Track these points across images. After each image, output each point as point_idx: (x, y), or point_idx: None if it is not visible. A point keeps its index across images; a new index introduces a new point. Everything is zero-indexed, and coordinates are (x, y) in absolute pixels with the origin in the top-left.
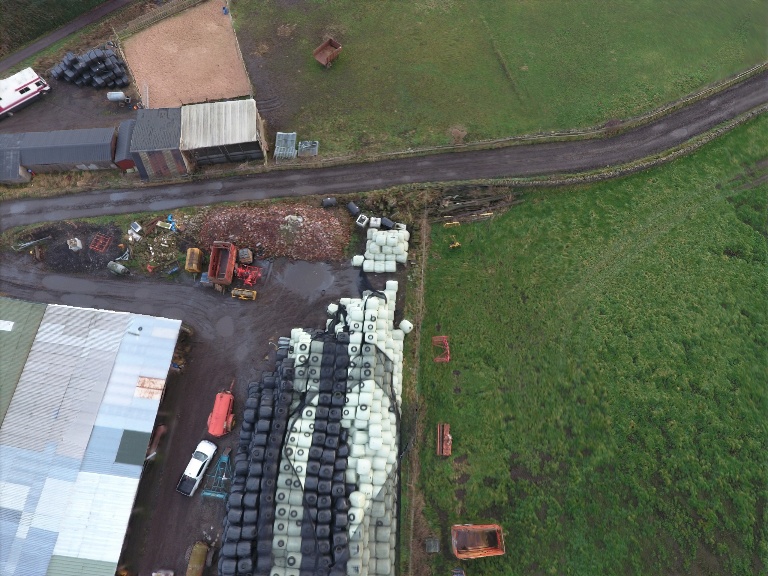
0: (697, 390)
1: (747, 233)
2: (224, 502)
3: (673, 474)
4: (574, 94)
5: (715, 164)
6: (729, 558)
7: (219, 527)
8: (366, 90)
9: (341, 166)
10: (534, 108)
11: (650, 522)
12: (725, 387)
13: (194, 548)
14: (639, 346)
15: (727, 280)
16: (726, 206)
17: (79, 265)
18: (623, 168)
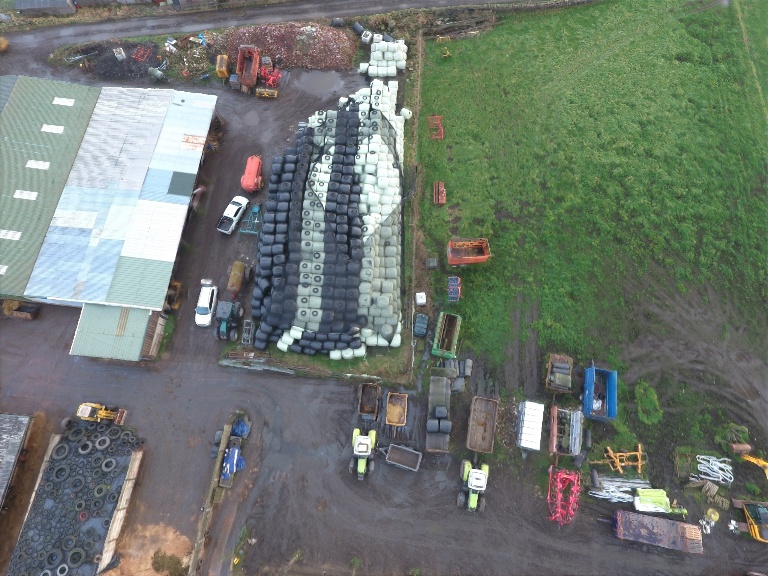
0: (650, 156)
1: (695, 44)
2: (257, 240)
3: (629, 213)
4: None
5: None
6: (674, 268)
7: (253, 257)
8: None
9: None
10: None
11: (610, 246)
12: (674, 153)
13: (235, 262)
14: (602, 125)
15: (677, 78)
16: (678, 25)
17: (123, 73)
18: None
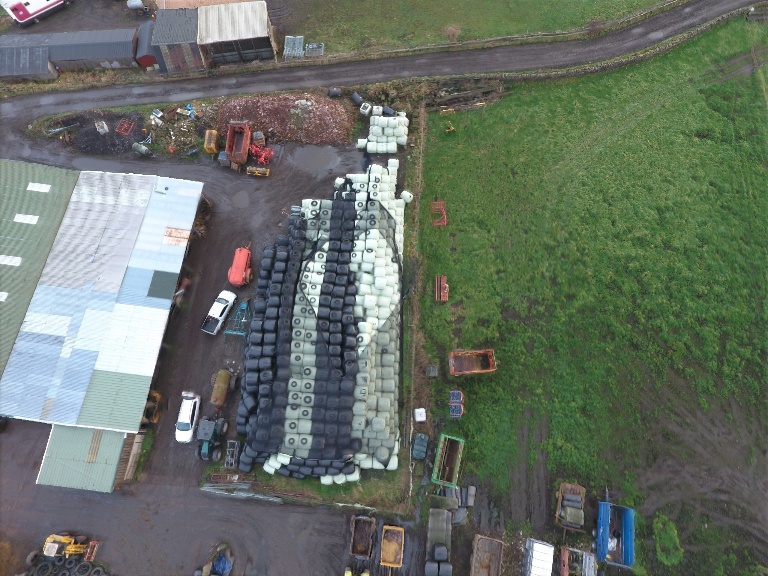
0: (669, 247)
1: (716, 119)
2: (244, 341)
3: (647, 314)
4: (559, 3)
5: (688, 62)
6: (695, 380)
7: (240, 361)
8: (367, 1)
9: (345, 63)
10: (523, 15)
11: (626, 353)
12: (694, 244)
13: (219, 371)
14: (617, 212)
15: (697, 158)
16: (697, 97)
17: (106, 148)
18: (604, 63)
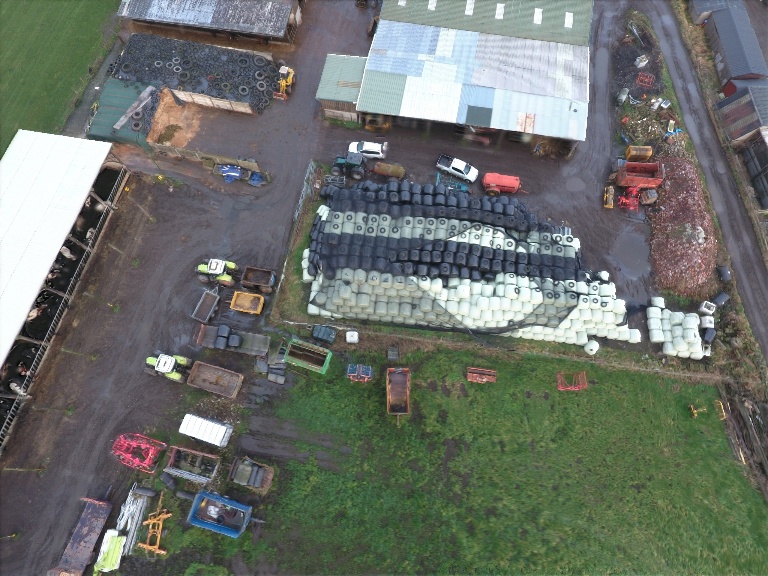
0: None
1: None
2: None
3: None
4: None
5: None
6: None
7: None
8: None
9: None
10: None
11: None
12: None
13: None
14: None
15: None
16: None
17: (621, 69)
18: None
